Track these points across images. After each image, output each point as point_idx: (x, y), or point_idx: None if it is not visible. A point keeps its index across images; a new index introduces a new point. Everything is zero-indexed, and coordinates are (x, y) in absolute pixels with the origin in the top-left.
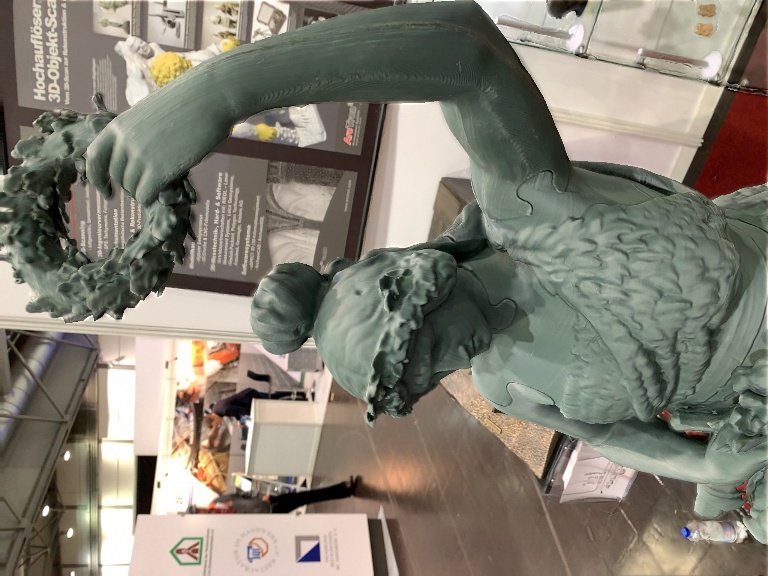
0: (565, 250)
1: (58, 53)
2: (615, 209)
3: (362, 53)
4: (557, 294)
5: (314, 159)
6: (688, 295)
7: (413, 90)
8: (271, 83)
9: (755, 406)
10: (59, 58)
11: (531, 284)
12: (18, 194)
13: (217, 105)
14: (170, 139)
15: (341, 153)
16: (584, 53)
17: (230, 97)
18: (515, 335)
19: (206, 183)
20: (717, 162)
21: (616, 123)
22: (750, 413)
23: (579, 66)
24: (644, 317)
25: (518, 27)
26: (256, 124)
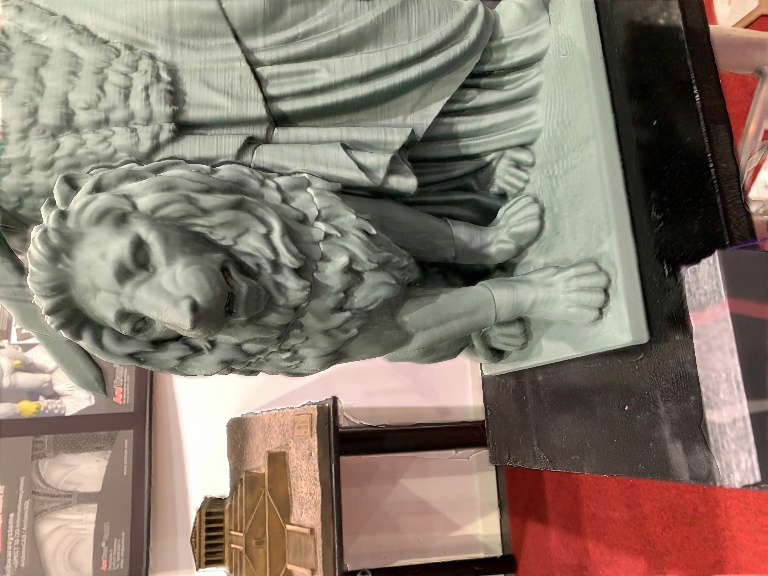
0: None
1: None
2: None
3: None
4: None
5: (83, 425)
6: None
7: None
8: None
9: None
10: None
11: None
12: None
13: None
14: None
15: (112, 413)
16: None
17: None
18: None
19: None
20: None
21: None
22: None
23: None
24: None
25: None
26: (18, 402)
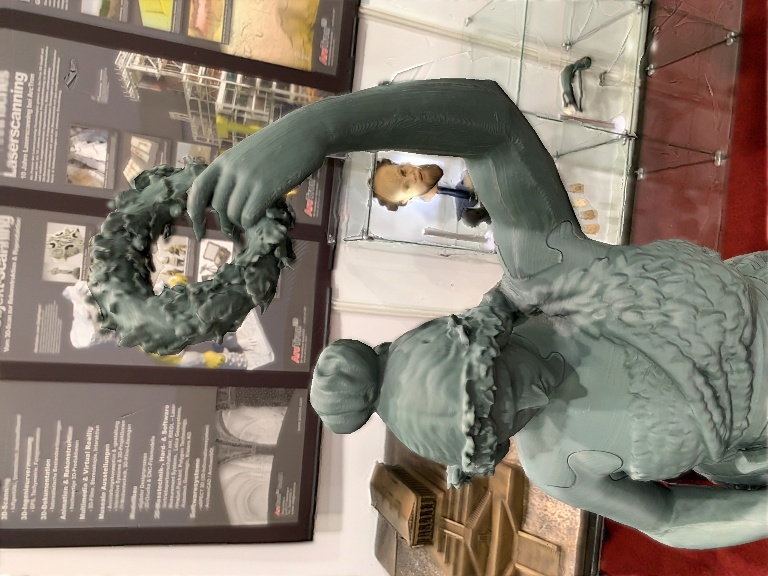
0: (600, 287)
1: (3, 302)
2: (631, 247)
3: (426, 99)
4: (601, 335)
5: (263, 380)
6: (719, 307)
7: (463, 136)
8: (360, 116)
9: None
10: (3, 307)
11: (572, 336)
12: (115, 236)
13: (318, 131)
14: (279, 158)
15: (290, 372)
16: None
17: (329, 125)
18: (567, 395)
19: (151, 418)
20: None
21: None
22: None
23: (493, 273)
24: (689, 334)
25: (442, 236)
26: (204, 352)
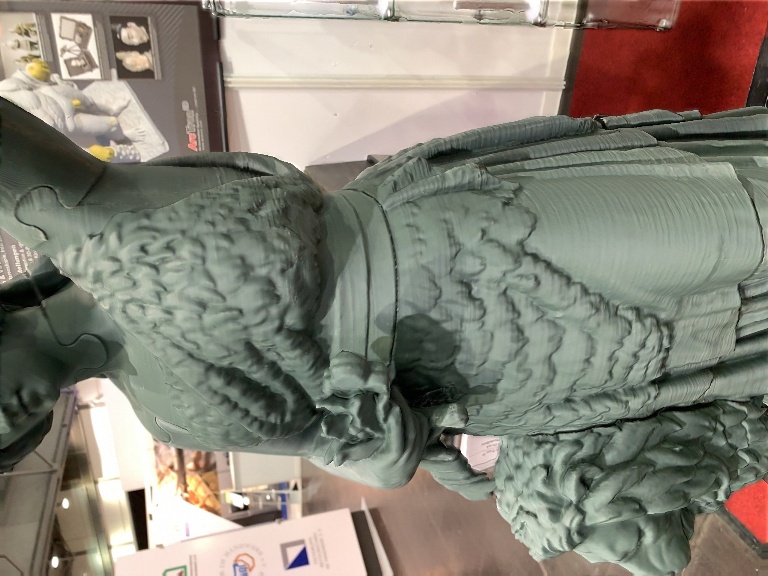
0: (95, 273)
1: None
2: (137, 216)
3: None
4: None
5: None
6: (233, 301)
7: None
8: None
9: (344, 411)
10: None
11: None
12: None
13: None
14: None
15: None
16: (392, 16)
17: None
18: (125, 369)
19: None
20: (580, 102)
21: (472, 80)
22: (349, 418)
23: (419, 28)
24: (196, 335)
25: (319, 0)
26: (88, 147)
